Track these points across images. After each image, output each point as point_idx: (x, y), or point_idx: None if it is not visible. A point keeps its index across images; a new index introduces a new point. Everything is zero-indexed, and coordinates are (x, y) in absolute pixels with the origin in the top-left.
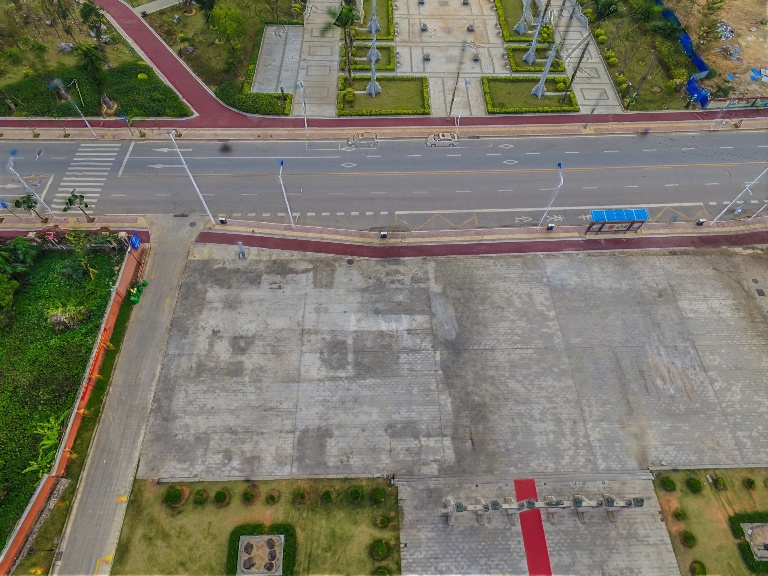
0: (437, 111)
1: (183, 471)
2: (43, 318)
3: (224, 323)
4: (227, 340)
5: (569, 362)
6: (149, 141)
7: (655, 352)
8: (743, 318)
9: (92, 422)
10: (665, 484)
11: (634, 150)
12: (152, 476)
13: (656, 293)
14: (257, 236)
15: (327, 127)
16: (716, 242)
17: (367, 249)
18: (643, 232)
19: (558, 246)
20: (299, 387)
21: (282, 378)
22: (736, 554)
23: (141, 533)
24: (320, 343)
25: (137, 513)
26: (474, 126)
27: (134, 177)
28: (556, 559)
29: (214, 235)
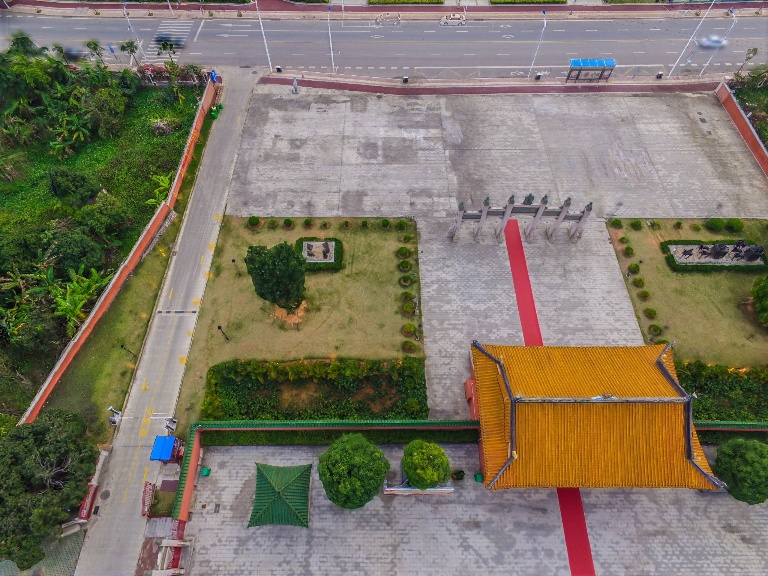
0: (449, 2)
1: (259, 211)
2: (145, 127)
3: (283, 131)
4: (286, 141)
5: (548, 158)
6: (216, 19)
7: (615, 153)
8: (687, 135)
9: (190, 184)
10: (614, 223)
11: (610, 30)
12: (236, 214)
13: (619, 119)
14: (306, 80)
15: (359, 11)
16: (671, 89)
17: (392, 89)
18: (613, 82)
19: (544, 90)
20: (342, 168)
21: (329, 163)
22: (663, 262)
23: (231, 243)
24: (357, 144)
25: (228, 232)
26: (479, 12)
27: (206, 42)
28: (531, 261)
29: (272, 79)
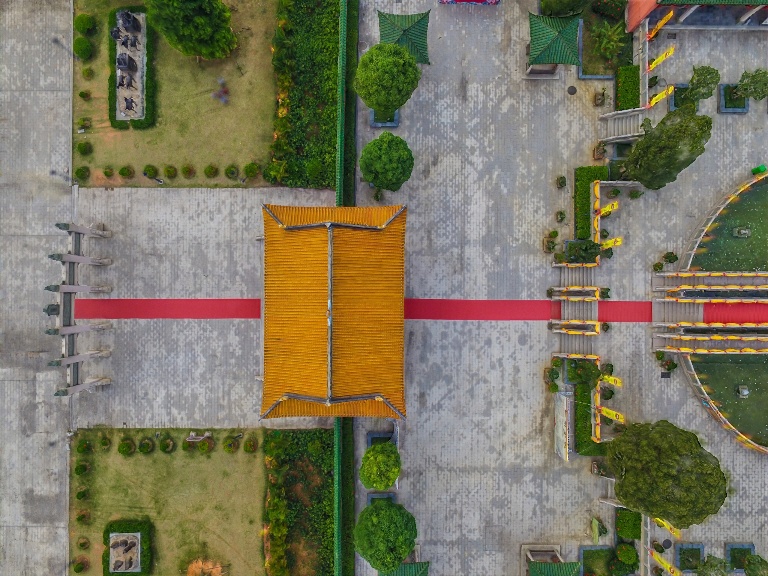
0: None
1: None
2: None
3: None
4: None
5: None
6: None
7: None
8: None
9: None
10: (81, 177)
11: None
12: None
13: None
14: None
15: None
16: None
17: None
18: None
19: None
20: None
21: None
22: (141, 133)
23: None
24: None
25: None
26: None
27: None
28: (139, 293)
29: None
